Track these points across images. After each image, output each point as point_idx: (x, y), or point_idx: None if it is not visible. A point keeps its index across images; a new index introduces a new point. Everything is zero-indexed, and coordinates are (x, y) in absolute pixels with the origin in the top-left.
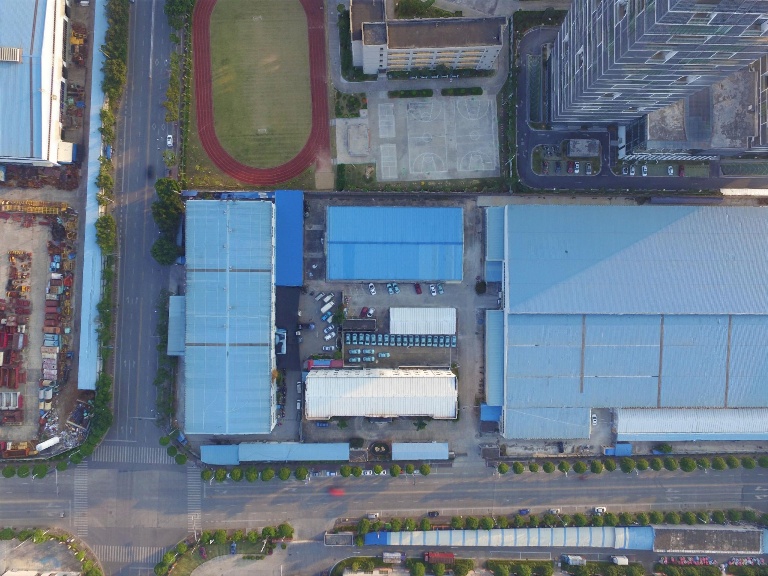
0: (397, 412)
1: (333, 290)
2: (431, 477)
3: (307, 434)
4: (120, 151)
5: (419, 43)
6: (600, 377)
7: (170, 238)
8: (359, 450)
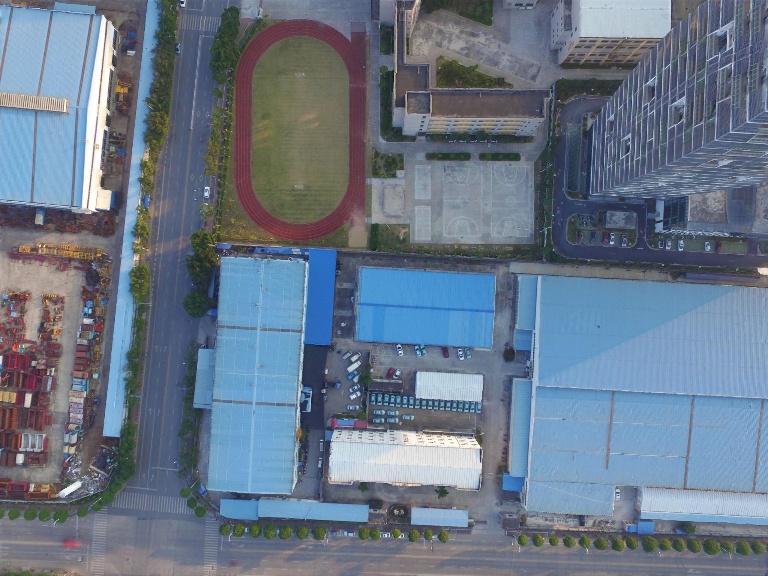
0: (420, 481)
1: (360, 349)
2: (449, 543)
3: (327, 492)
4: (157, 200)
5: (461, 112)
6: (627, 455)
7: (202, 290)
8: (378, 512)
